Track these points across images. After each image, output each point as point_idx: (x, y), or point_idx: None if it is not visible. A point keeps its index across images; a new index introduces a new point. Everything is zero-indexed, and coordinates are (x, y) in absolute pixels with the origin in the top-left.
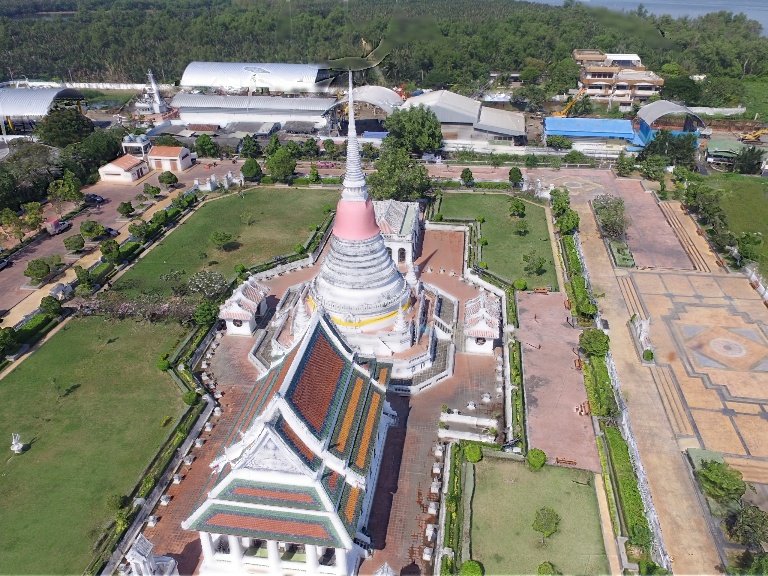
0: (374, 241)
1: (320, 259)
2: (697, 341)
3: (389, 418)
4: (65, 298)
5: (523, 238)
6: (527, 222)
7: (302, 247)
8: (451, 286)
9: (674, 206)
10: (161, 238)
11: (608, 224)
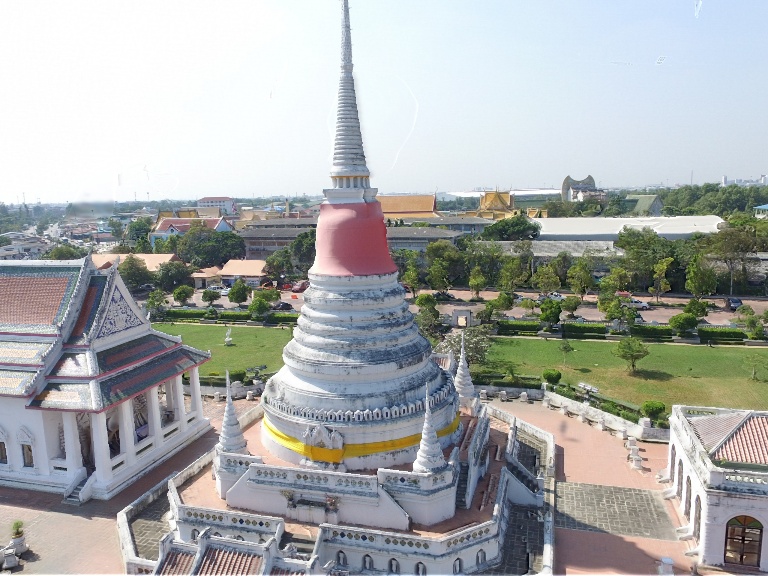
0: (321, 286)
1: (661, 445)
2: None
3: (71, 482)
4: (467, 326)
5: None
6: None
7: (654, 405)
8: None
9: None
10: (649, 342)
11: None
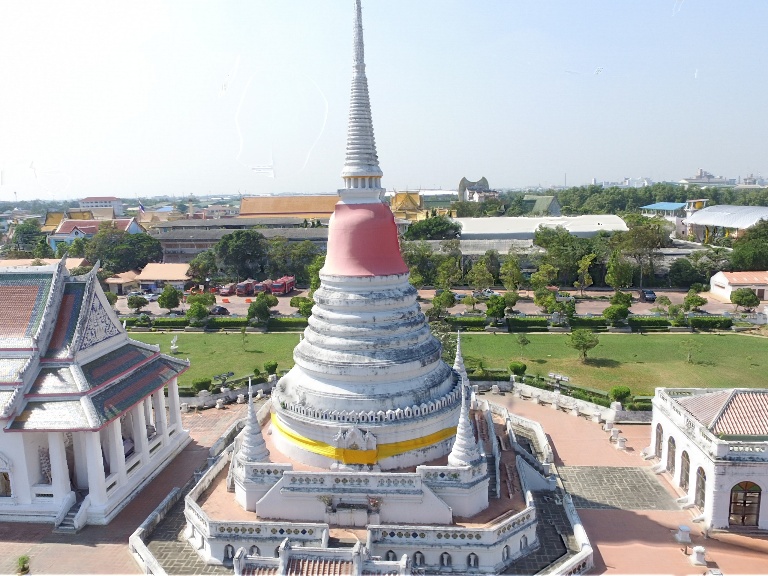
0: (338, 287)
1: (633, 425)
2: None
3: (61, 508)
4: None
5: None
6: None
7: (622, 390)
8: None
9: None
10: None
11: None
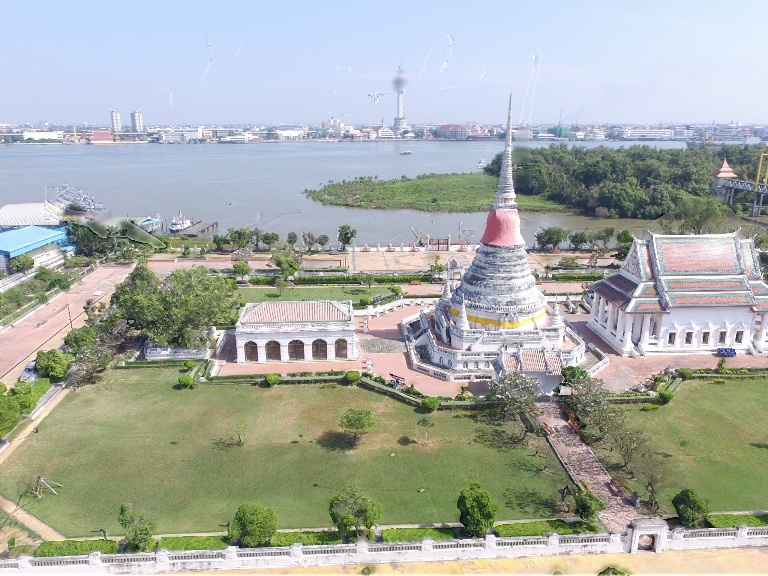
0: None
1: None
2: (443, 263)
3: None
4: None
5: (288, 295)
6: (246, 294)
7: None
8: (393, 318)
9: (220, 256)
10: None
11: (291, 259)
